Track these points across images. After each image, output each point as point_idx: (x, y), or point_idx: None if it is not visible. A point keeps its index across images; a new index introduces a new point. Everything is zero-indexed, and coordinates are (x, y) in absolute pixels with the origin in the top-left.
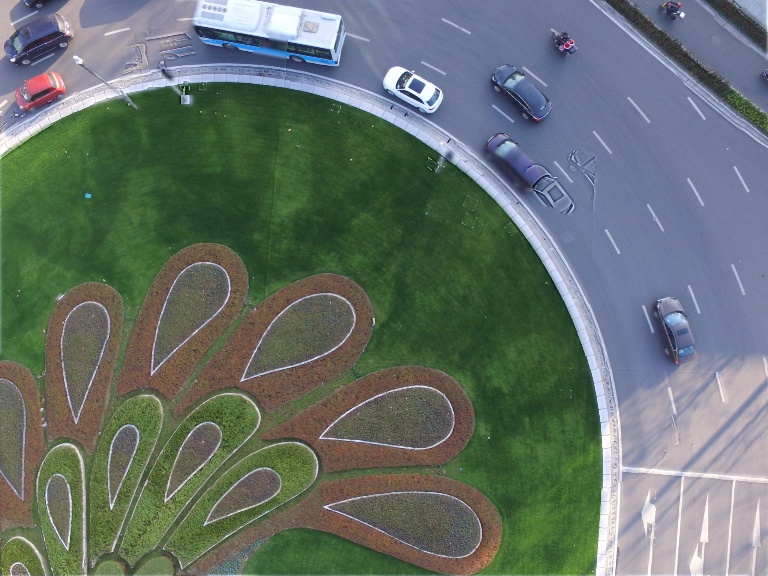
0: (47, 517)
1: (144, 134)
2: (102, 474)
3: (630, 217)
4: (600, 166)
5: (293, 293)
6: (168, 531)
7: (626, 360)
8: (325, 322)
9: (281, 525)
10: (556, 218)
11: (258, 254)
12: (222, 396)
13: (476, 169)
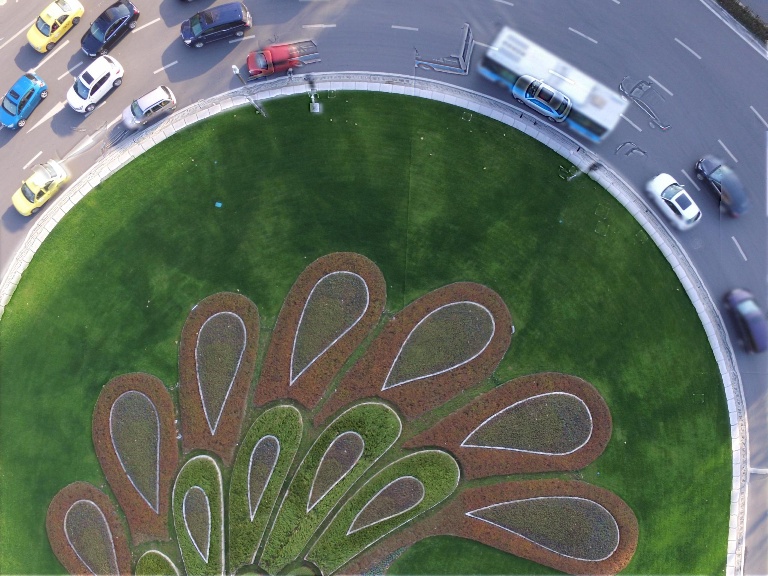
0: (185, 530)
1: (274, 142)
2: (242, 486)
3: (756, 224)
4: (726, 174)
5: (433, 302)
6: (309, 541)
7: (754, 364)
8: (466, 330)
9: (424, 533)
10: (684, 226)
11: (395, 263)
12: (363, 405)
13: (606, 177)
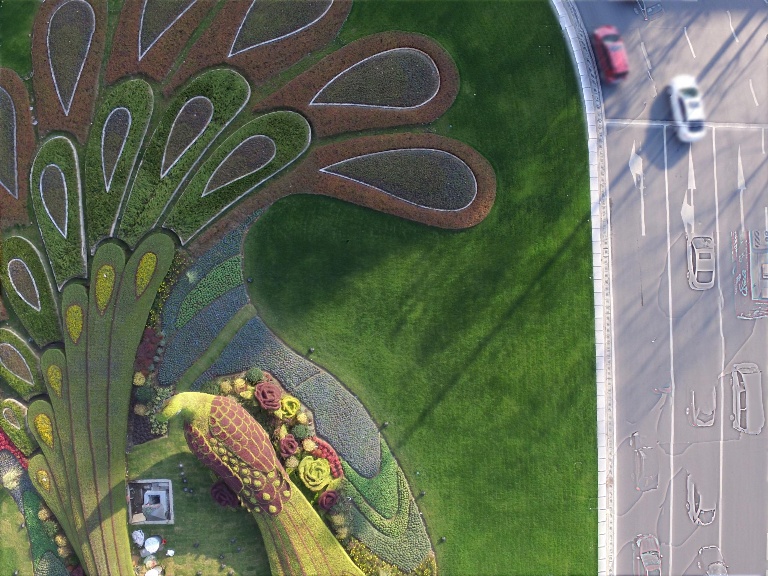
0: (43, 208)
1: None
2: (96, 157)
3: None
4: None
5: None
6: (166, 210)
7: (598, 18)
8: None
9: (279, 191)
10: None
11: None
12: (211, 71)
13: None
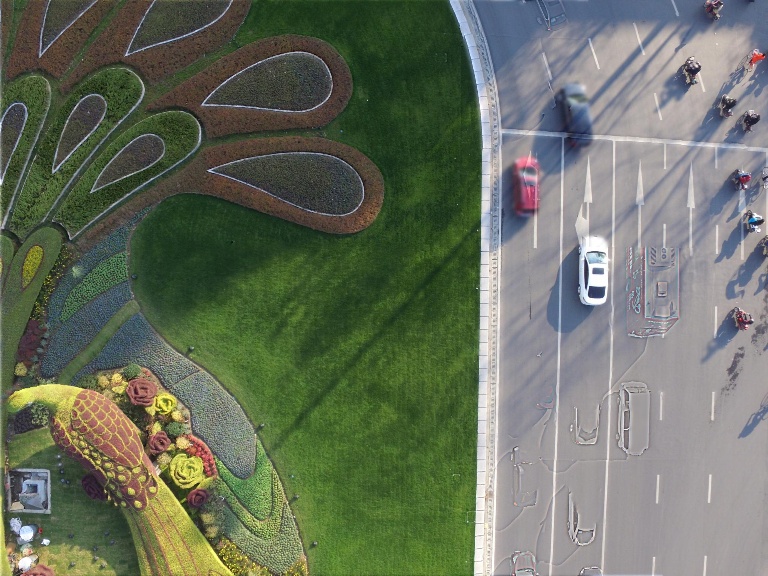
0: None
1: None
2: None
3: None
4: None
5: None
6: (57, 205)
7: (499, 27)
8: None
9: (166, 189)
10: None
11: None
12: (107, 70)
13: None
